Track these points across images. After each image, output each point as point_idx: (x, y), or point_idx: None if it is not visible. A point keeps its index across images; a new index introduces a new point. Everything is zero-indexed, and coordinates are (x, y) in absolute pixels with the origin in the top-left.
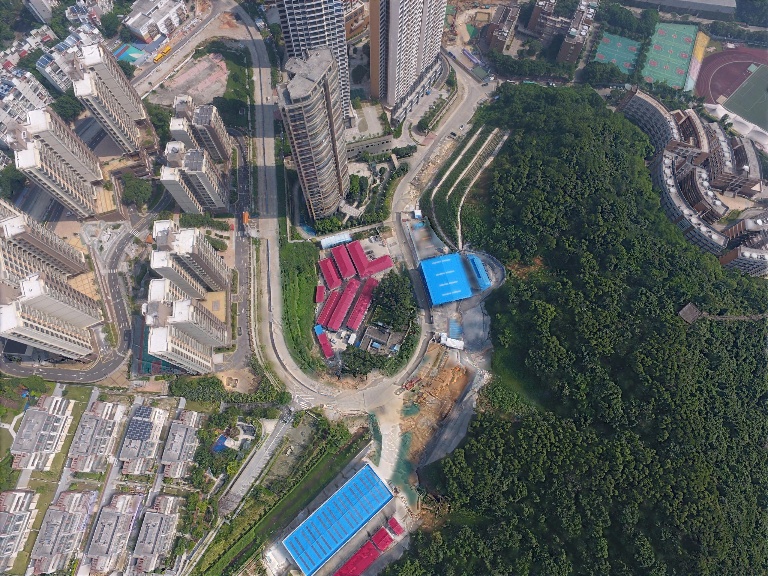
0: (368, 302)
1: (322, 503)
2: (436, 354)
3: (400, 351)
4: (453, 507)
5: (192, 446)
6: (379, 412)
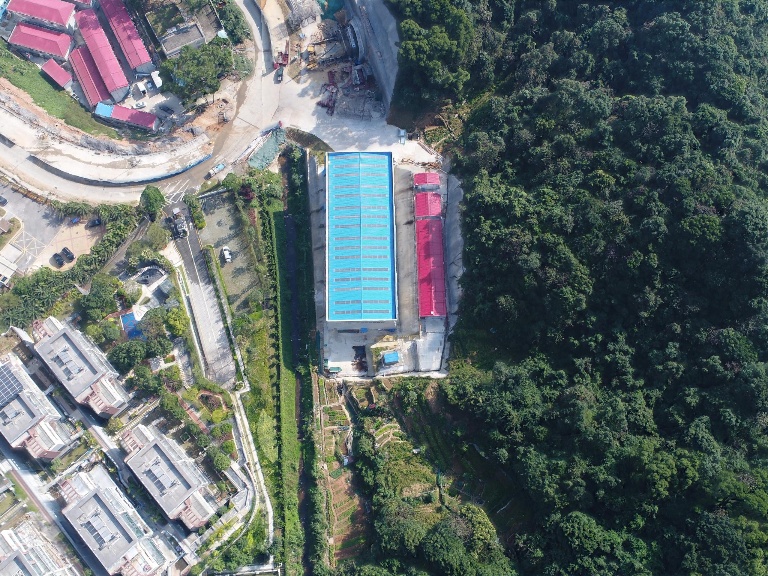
0: (128, 19)
1: (325, 240)
2: (275, 2)
3: (230, 37)
4: (462, 112)
5: None
6: (281, 117)
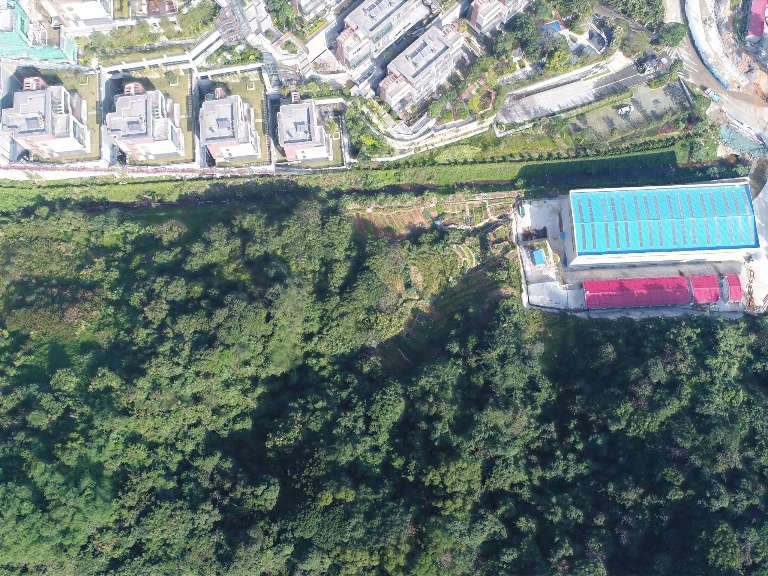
0: None
1: None
2: None
3: None
4: None
5: (517, 4)
6: None
